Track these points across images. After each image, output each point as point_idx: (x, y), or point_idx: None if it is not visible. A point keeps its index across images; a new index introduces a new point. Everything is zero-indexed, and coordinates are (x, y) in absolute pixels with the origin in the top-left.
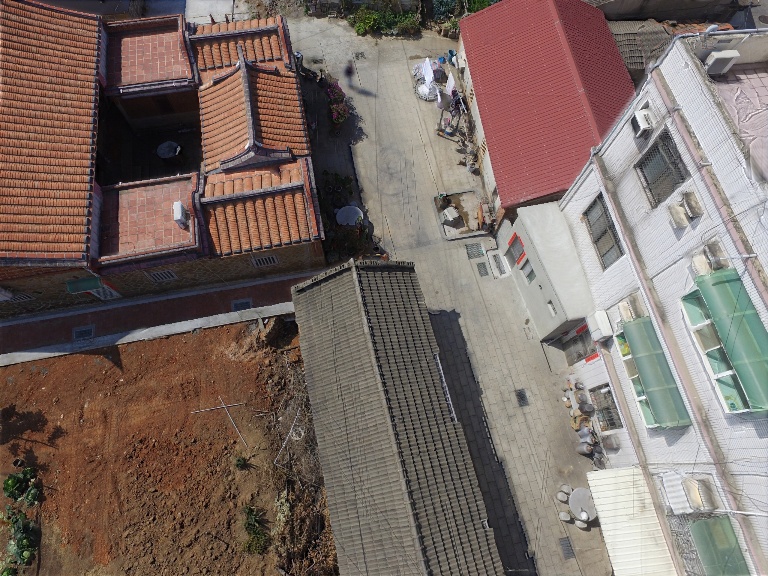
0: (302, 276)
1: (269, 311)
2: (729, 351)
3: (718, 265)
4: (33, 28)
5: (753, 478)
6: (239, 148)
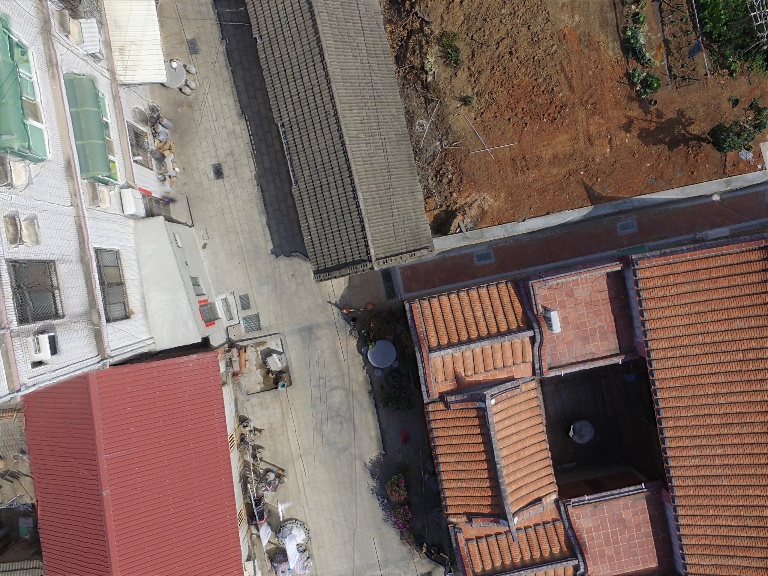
0: (428, 290)
1: (456, 239)
2: (14, 73)
3: (2, 157)
4: (759, 553)
5: (21, 4)
6: (502, 404)
